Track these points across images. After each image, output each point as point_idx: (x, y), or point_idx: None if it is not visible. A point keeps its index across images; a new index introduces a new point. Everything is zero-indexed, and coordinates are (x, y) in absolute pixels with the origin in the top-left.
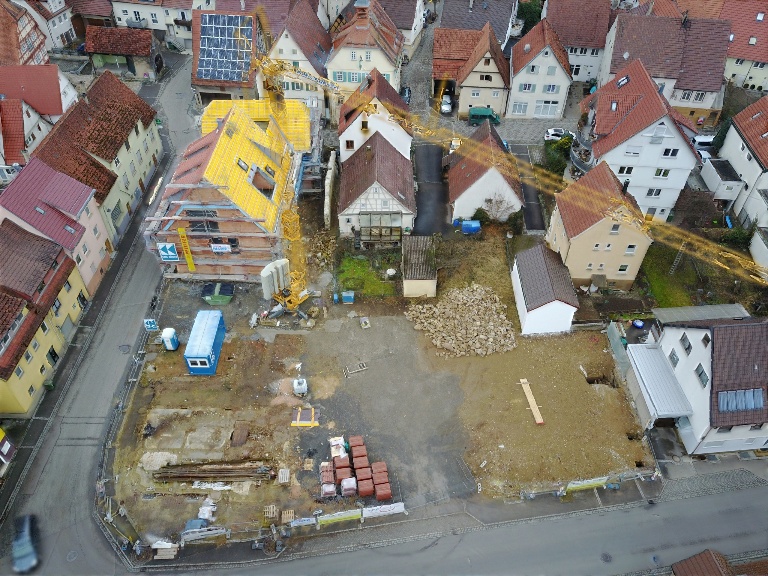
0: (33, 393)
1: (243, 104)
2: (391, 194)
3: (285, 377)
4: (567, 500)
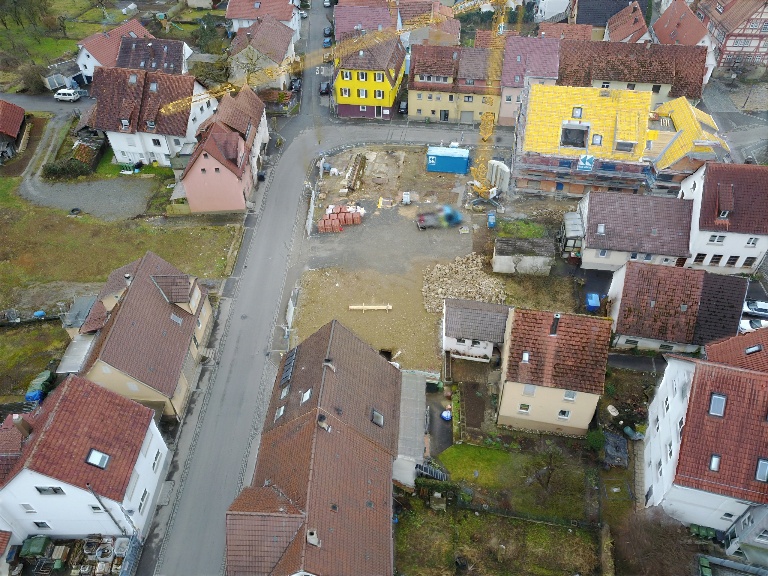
0: (420, 114)
1: (686, 111)
2: (588, 211)
3: (420, 196)
4: None
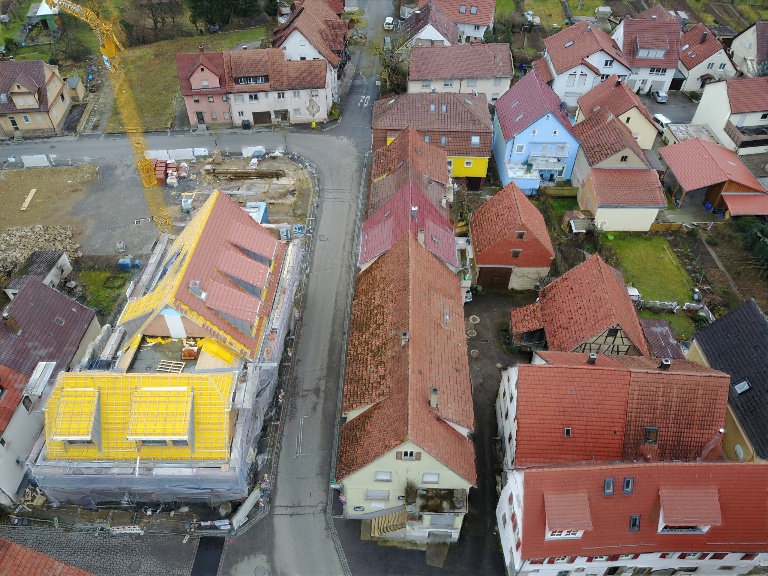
0: None
1: (160, 374)
2: None
3: None
4: None
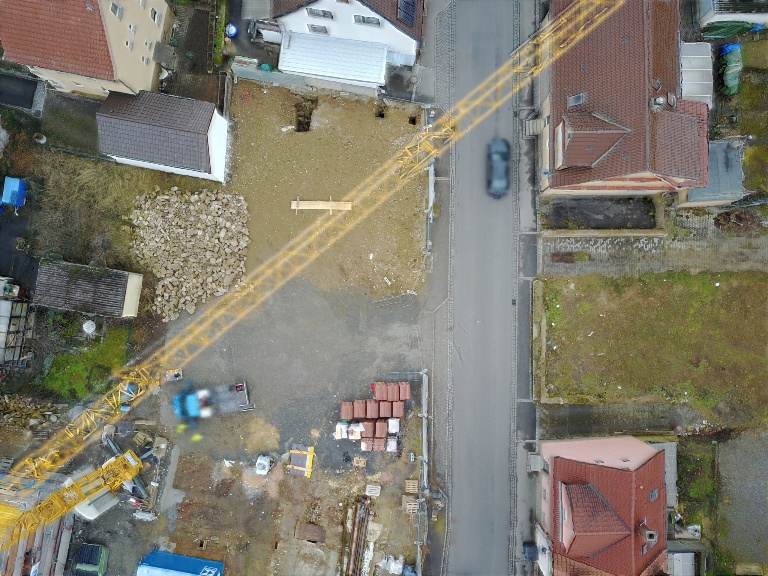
0: None
1: None
2: None
3: (241, 480)
4: (438, 210)
